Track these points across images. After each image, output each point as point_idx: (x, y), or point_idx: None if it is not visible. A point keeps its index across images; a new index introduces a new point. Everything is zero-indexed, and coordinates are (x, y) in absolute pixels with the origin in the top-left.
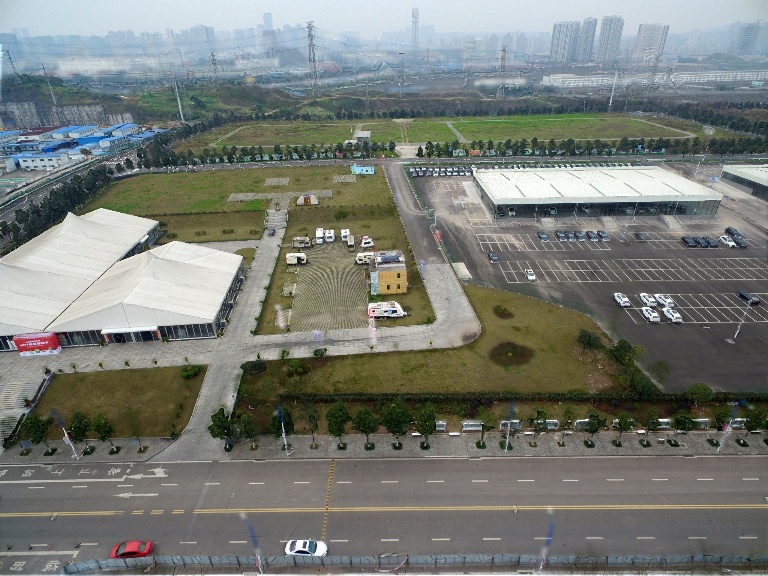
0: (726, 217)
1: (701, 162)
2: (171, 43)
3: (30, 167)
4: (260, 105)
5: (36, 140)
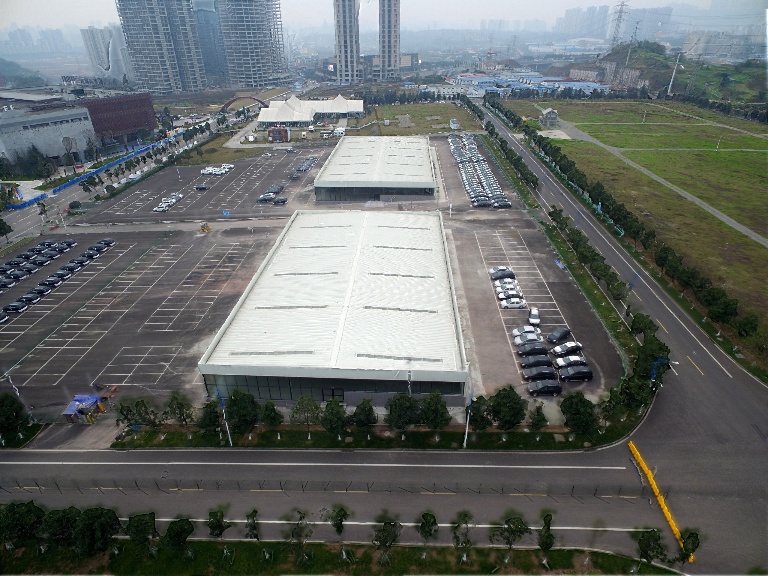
0: (317, 209)
1: (546, 242)
2: (766, 13)
3: (473, 93)
4: (762, 92)
5: (543, 85)
